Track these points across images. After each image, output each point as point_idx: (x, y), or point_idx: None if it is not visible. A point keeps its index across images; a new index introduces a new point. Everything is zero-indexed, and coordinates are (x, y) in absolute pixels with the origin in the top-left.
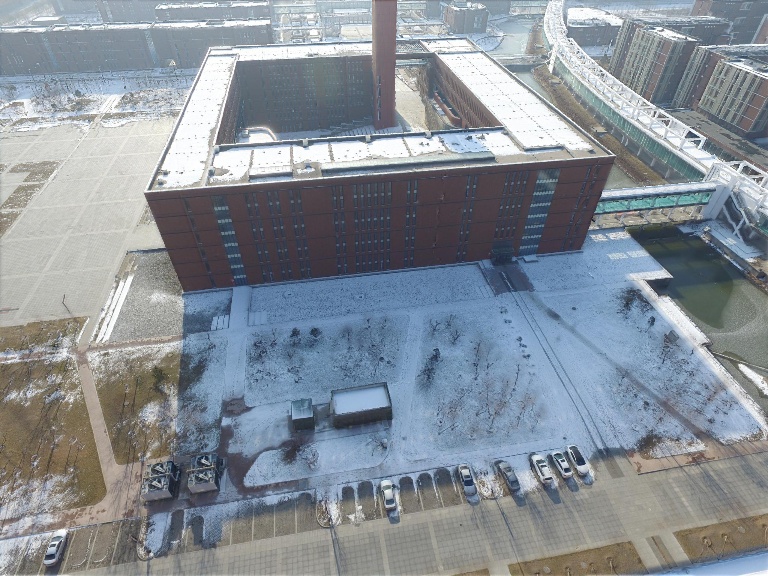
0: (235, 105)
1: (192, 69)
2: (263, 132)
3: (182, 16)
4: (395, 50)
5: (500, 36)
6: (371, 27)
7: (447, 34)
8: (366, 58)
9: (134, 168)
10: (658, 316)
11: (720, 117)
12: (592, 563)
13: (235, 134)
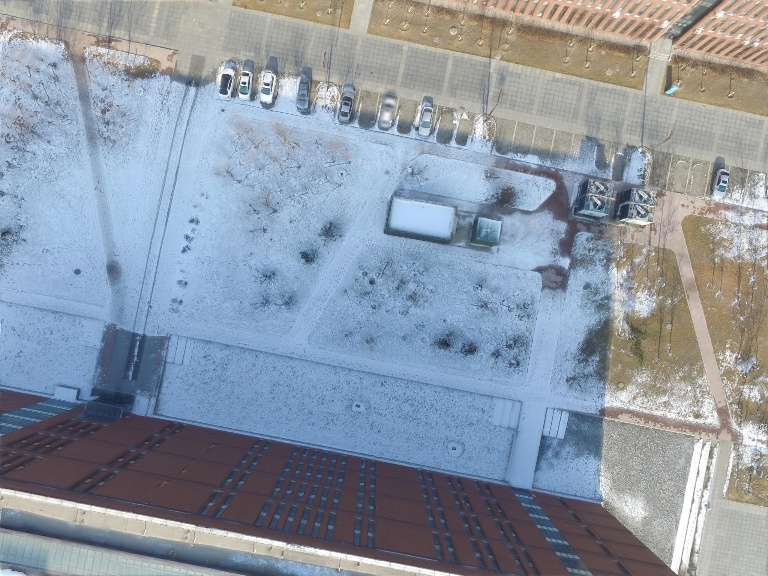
0: None
1: None
2: None
3: None
4: None
5: None
6: None
7: None
8: None
9: None
10: None
11: None
12: (278, 3)
13: None
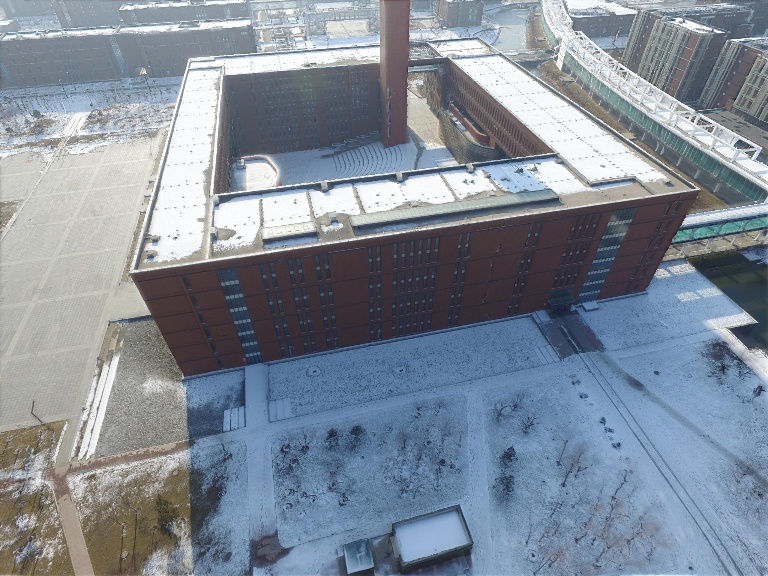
0: (226, 130)
1: (166, 78)
2: (261, 161)
3: (150, 17)
4: (407, 58)
5: (496, 29)
6: (357, 22)
7: (440, 28)
8: (371, 66)
9: (109, 206)
10: (756, 378)
11: (761, 119)
12: None
13: (229, 166)
